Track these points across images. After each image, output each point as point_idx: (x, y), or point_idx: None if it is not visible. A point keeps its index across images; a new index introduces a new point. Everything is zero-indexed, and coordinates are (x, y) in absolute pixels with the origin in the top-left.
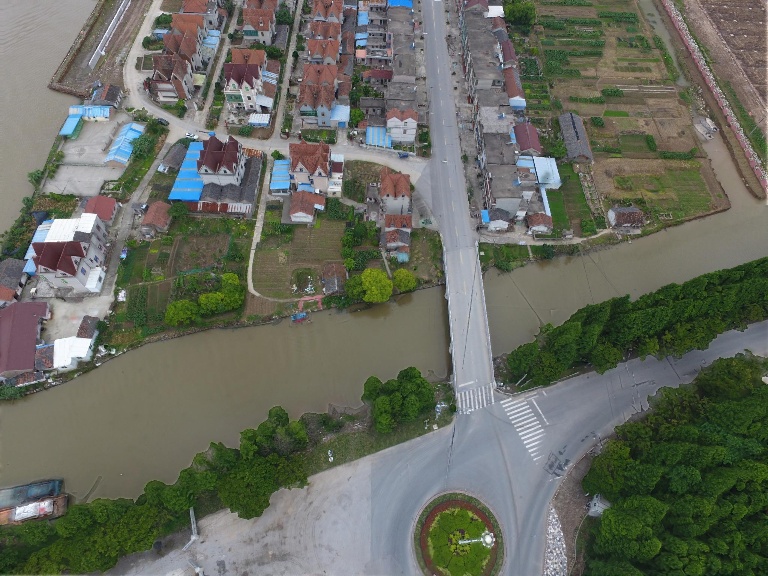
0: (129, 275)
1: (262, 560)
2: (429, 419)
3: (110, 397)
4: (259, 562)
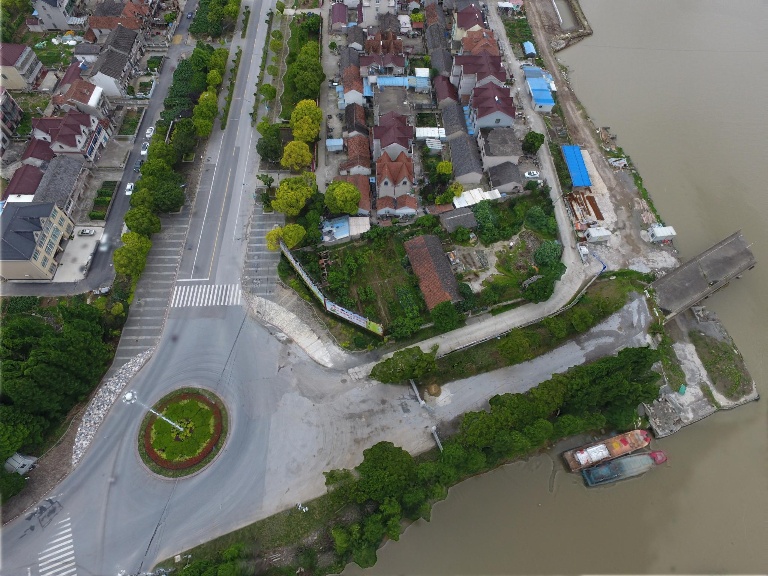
0: None
1: (370, 414)
2: (183, 569)
3: None
4: (373, 412)
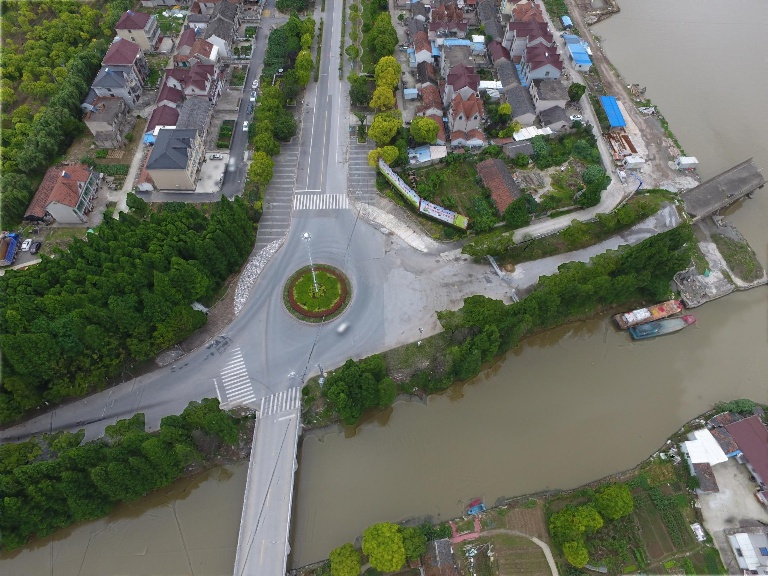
0: (710, 567)
1: (461, 283)
2: None
3: (639, 416)
4: (463, 282)
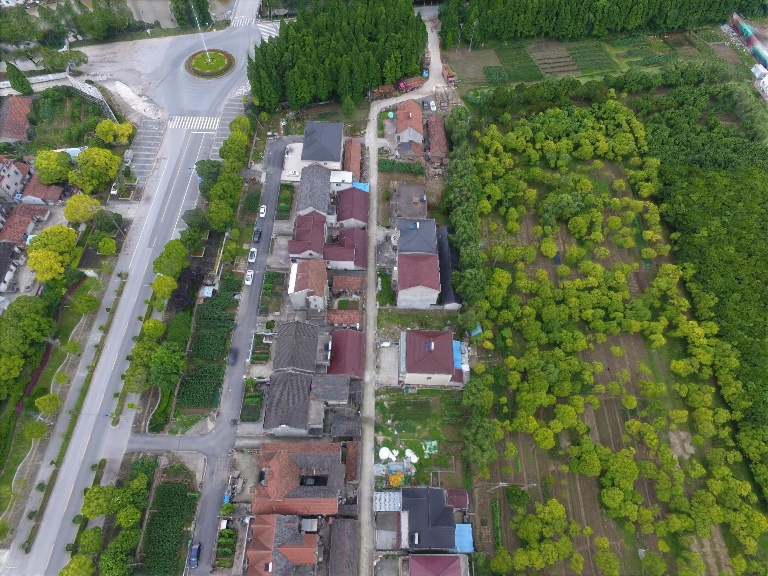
0: None
1: (102, 62)
2: (212, 27)
3: None
4: (100, 62)
